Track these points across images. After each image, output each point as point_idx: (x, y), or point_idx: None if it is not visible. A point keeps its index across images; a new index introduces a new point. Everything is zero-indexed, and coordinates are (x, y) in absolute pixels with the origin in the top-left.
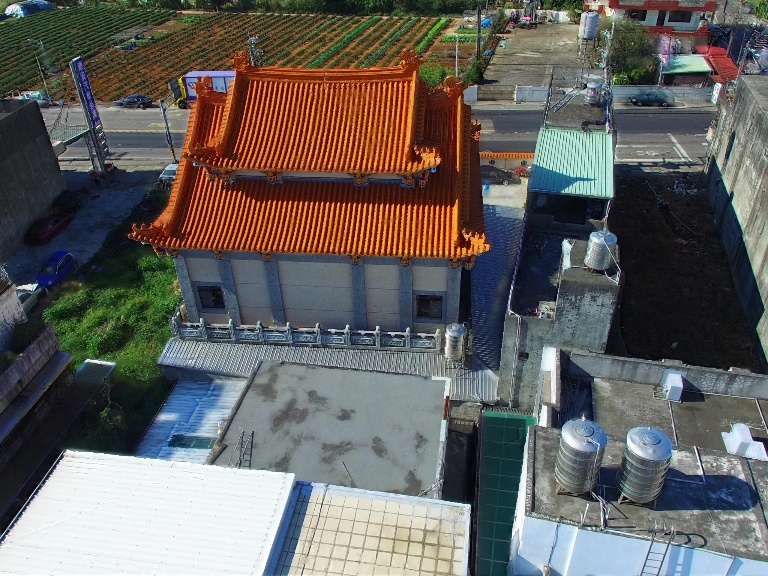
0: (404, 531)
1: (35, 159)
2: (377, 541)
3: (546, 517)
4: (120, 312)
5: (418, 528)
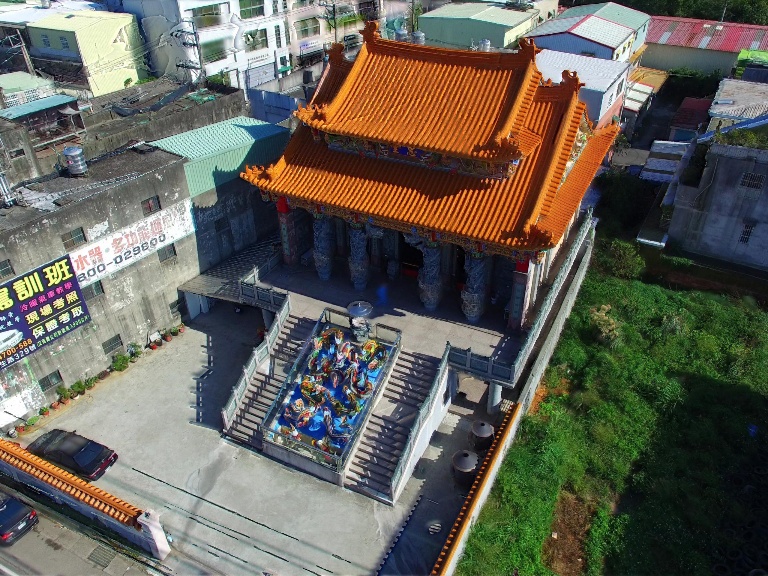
0: None
1: None
2: None
3: None
4: (676, 339)
5: None
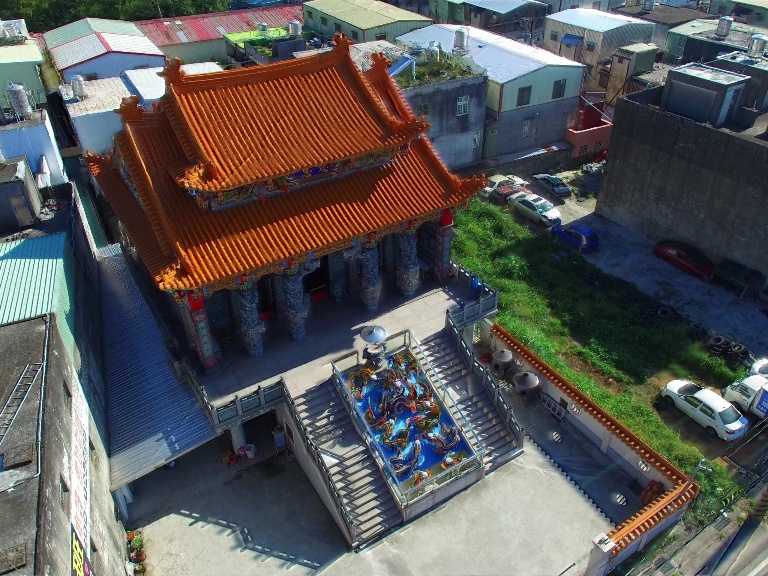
0: (96, 108)
1: (750, 208)
2: (105, 105)
3: (36, 110)
4: None
5: (91, 110)
